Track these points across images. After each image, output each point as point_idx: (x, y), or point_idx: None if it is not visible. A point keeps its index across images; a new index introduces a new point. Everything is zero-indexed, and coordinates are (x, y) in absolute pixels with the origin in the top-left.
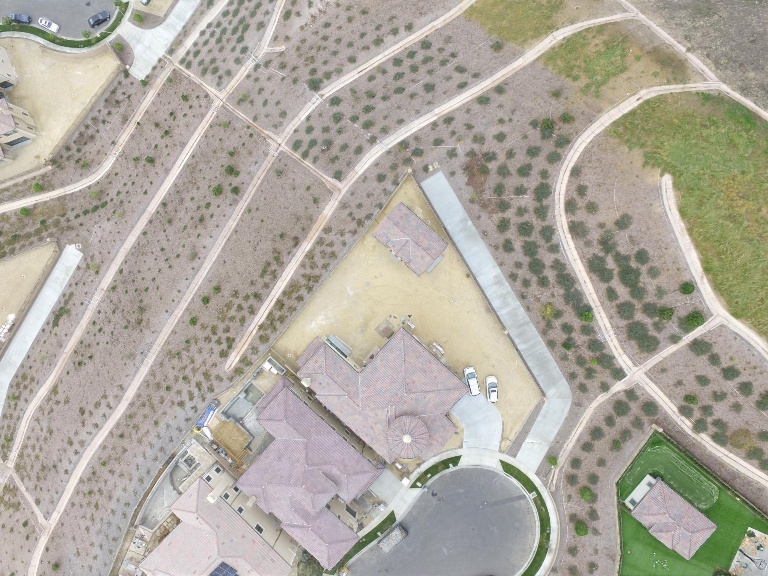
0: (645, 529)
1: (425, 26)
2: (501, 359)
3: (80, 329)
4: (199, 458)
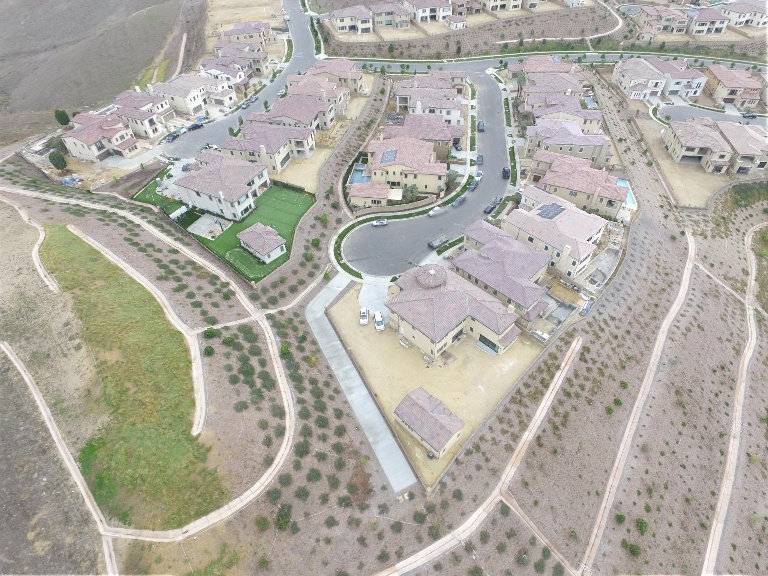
0: None
1: None
2: (354, 336)
3: (740, 401)
4: (586, 283)
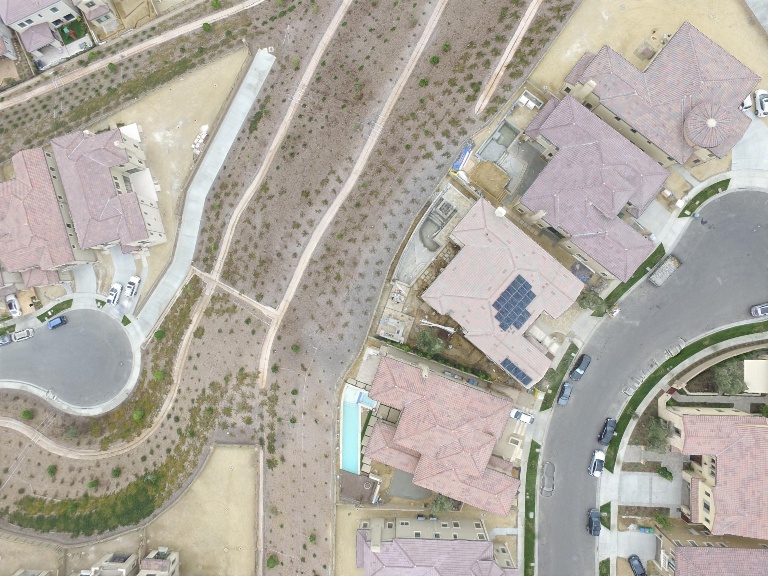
0: None
1: None
2: (767, 73)
3: (284, 126)
4: (456, 204)
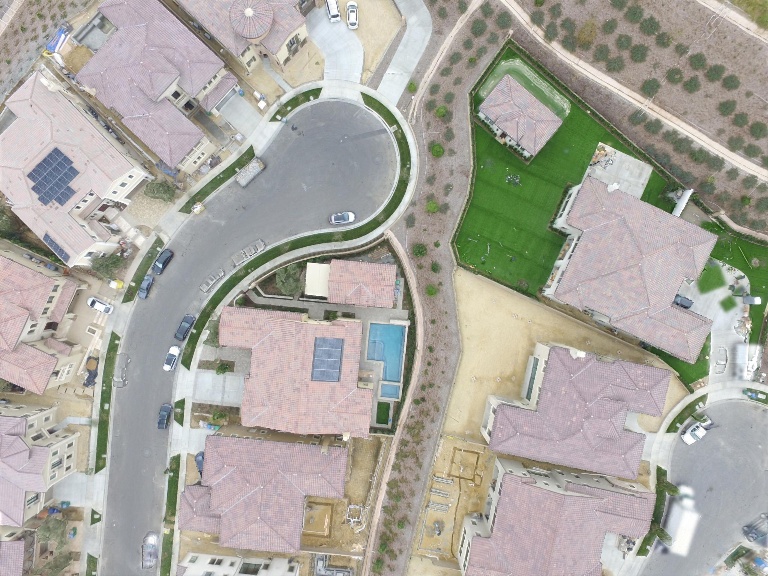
0: (498, 143)
1: None
2: None
3: None
4: None
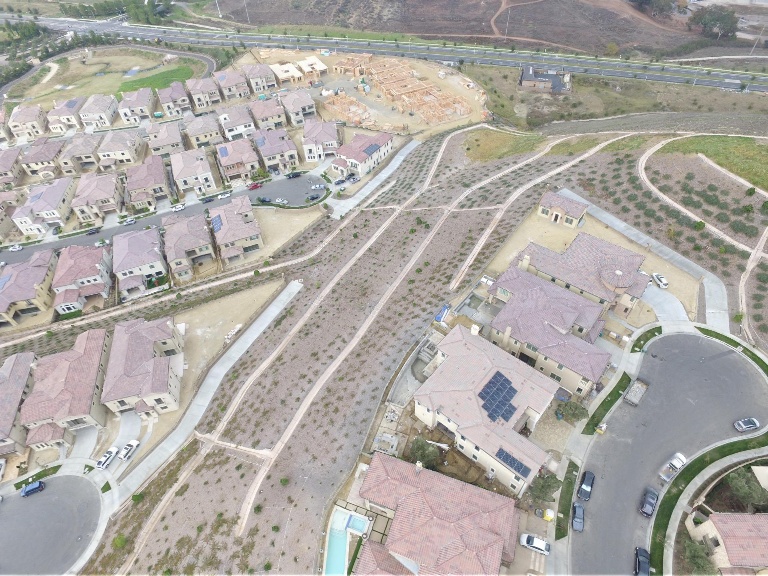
0: None
1: (524, 161)
2: (655, 266)
3: (303, 320)
4: None
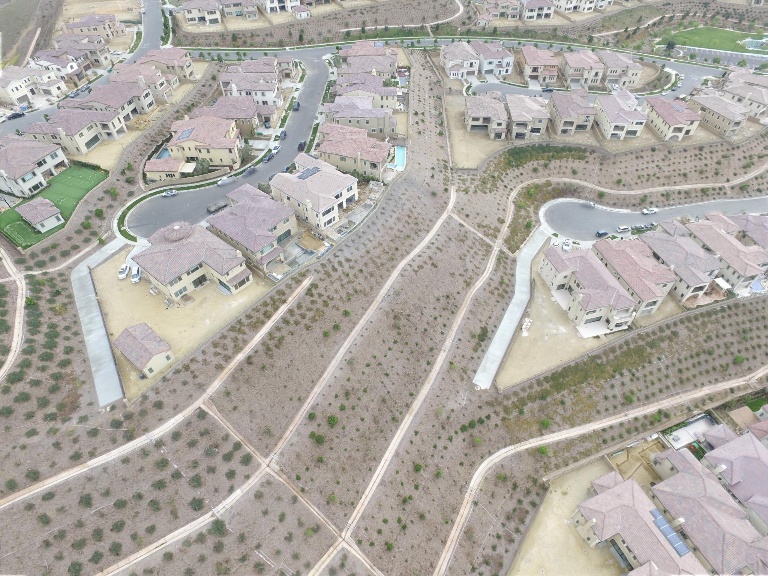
0: None
1: None
2: (111, 289)
3: (458, 323)
4: (333, 233)
